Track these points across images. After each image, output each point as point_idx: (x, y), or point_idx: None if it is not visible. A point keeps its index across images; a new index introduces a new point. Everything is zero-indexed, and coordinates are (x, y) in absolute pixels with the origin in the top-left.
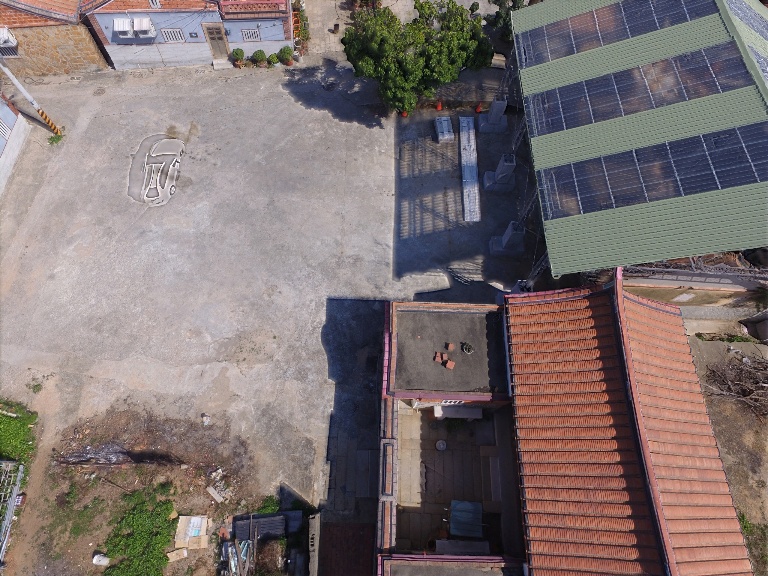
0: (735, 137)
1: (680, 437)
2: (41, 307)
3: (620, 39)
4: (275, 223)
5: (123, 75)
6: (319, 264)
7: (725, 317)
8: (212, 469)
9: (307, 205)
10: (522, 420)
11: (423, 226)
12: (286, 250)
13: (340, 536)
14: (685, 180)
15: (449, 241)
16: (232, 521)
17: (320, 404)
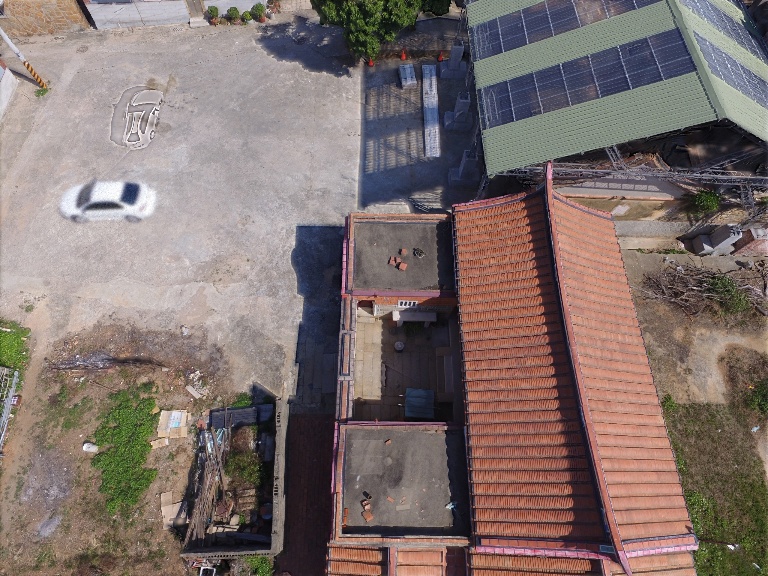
0: (646, 45)
1: (604, 316)
2: (31, 239)
3: None
4: (248, 162)
5: (104, 34)
6: (289, 197)
7: (663, 234)
8: (191, 371)
9: (278, 146)
10: (464, 307)
11: (387, 162)
12: (259, 185)
13: (307, 425)
14: (603, 85)
15: (411, 175)
16: (209, 414)
17: (290, 316)
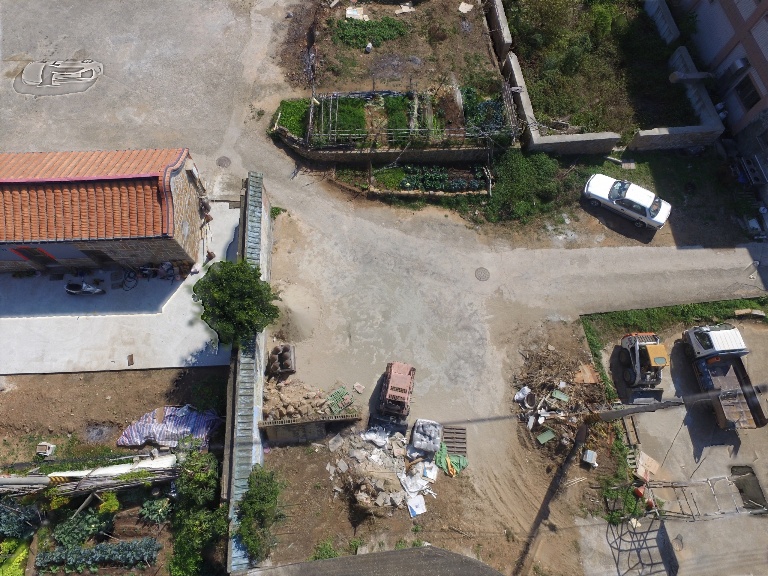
0: None
1: None
2: (192, 125)
3: None
4: None
5: None
6: None
7: None
8: (320, 7)
9: None
10: None
11: None
12: None
13: None
14: None
15: None
16: None
17: None
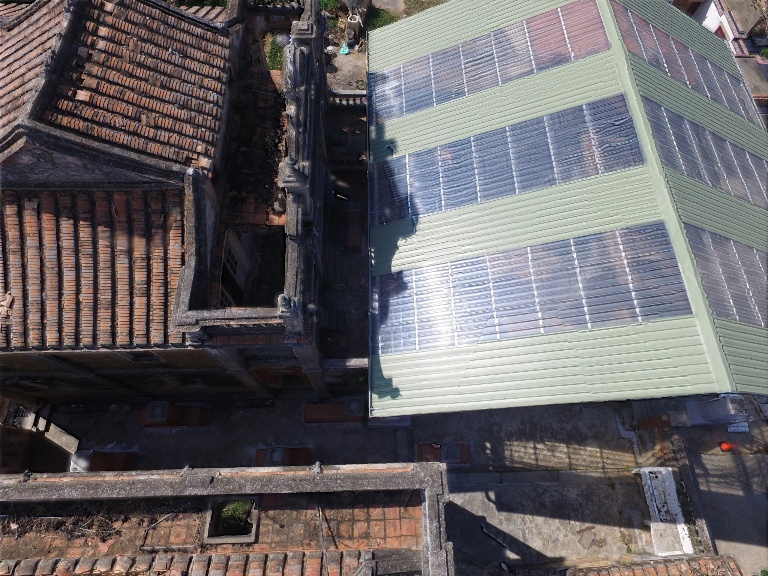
0: None
1: None
2: None
3: (764, 254)
4: None
5: None
6: None
7: None
8: None
9: None
10: None
11: None
12: None
13: None
14: None
15: None
16: None
17: None
